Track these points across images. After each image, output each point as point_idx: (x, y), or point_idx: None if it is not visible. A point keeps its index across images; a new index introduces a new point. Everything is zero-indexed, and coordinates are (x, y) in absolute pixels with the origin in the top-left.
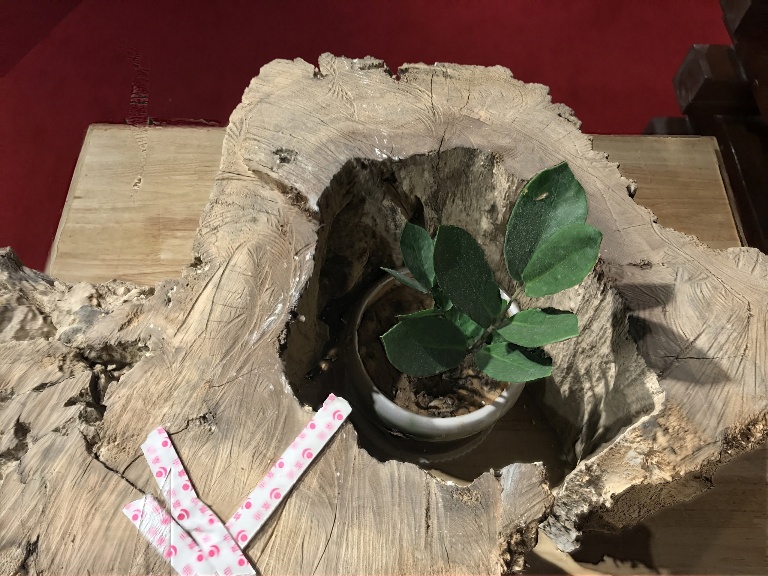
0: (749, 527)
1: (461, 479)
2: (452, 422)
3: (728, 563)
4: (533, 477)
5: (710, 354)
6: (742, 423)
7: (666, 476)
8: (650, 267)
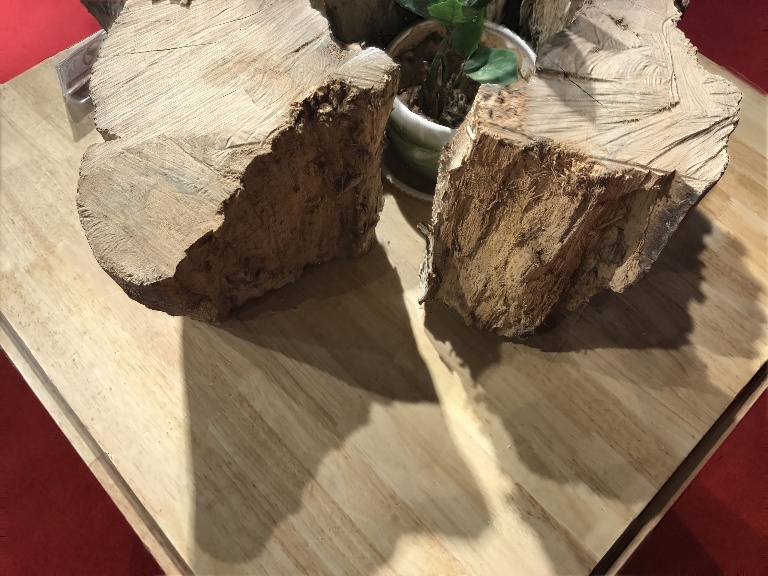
0: (583, 431)
1: (404, 216)
2: (412, 115)
3: (536, 431)
4: (384, 65)
5: (598, 97)
6: (567, 148)
7: (472, 134)
8: (624, 29)
